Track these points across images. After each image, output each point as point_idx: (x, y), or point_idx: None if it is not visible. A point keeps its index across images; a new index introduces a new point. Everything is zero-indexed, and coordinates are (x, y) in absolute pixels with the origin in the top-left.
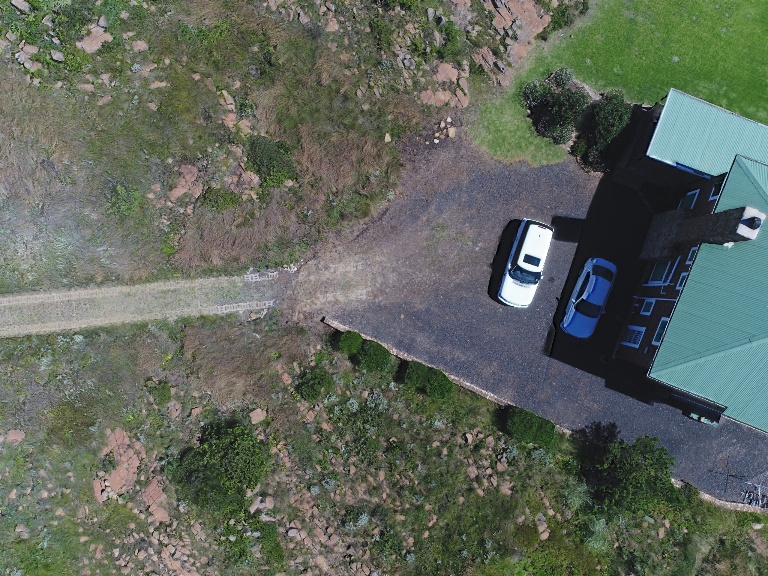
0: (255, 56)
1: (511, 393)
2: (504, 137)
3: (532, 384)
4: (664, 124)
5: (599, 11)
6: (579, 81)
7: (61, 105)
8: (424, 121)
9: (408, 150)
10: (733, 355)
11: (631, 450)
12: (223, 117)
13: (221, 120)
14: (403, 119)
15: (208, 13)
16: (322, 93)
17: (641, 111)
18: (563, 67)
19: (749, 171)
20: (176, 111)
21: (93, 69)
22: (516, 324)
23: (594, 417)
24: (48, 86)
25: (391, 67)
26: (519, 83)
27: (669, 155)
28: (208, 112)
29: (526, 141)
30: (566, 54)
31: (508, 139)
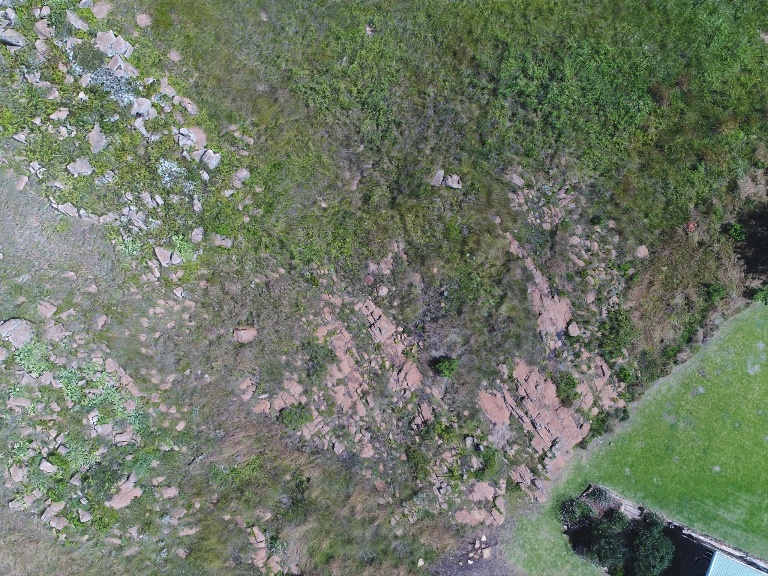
0: (287, 485)
1: None
2: (540, 556)
3: None
4: None
5: (639, 415)
6: (617, 492)
7: (87, 560)
8: (458, 541)
9: (441, 571)
10: None
11: None
12: (253, 556)
13: (251, 559)
14: (437, 546)
15: (241, 450)
16: (355, 523)
17: (681, 538)
18: (602, 489)
19: None
20: (205, 562)
21: (121, 525)
22: None
23: None
24: (74, 541)
25: (427, 496)
26: (556, 495)
27: None
28: (238, 554)
29: (562, 560)
30: (605, 463)
31: (544, 558)
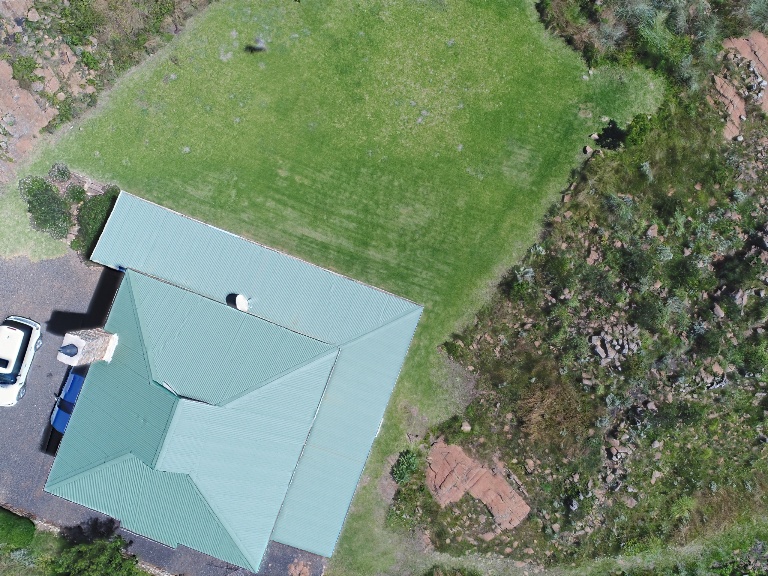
0: None
1: (4, 491)
2: (2, 233)
3: (26, 482)
4: (111, 228)
5: (112, 103)
6: (86, 174)
7: None
8: None
9: None
10: (97, 474)
11: (87, 554)
12: None
13: None
14: None
15: None
16: None
17: None
18: (57, 163)
19: (130, 286)
20: None
21: None
22: (11, 421)
23: (91, 513)
24: None
25: None
26: (22, 177)
27: (113, 259)
28: None
29: (25, 236)
30: (74, 147)
31: (7, 235)
